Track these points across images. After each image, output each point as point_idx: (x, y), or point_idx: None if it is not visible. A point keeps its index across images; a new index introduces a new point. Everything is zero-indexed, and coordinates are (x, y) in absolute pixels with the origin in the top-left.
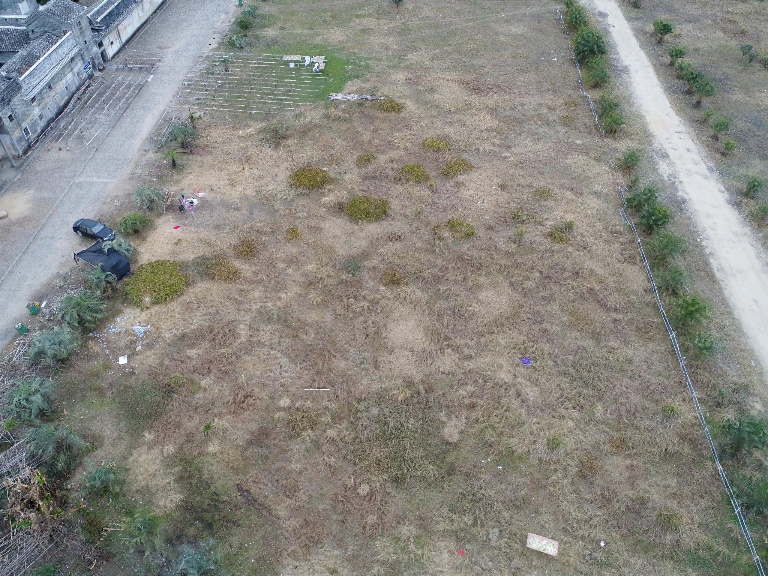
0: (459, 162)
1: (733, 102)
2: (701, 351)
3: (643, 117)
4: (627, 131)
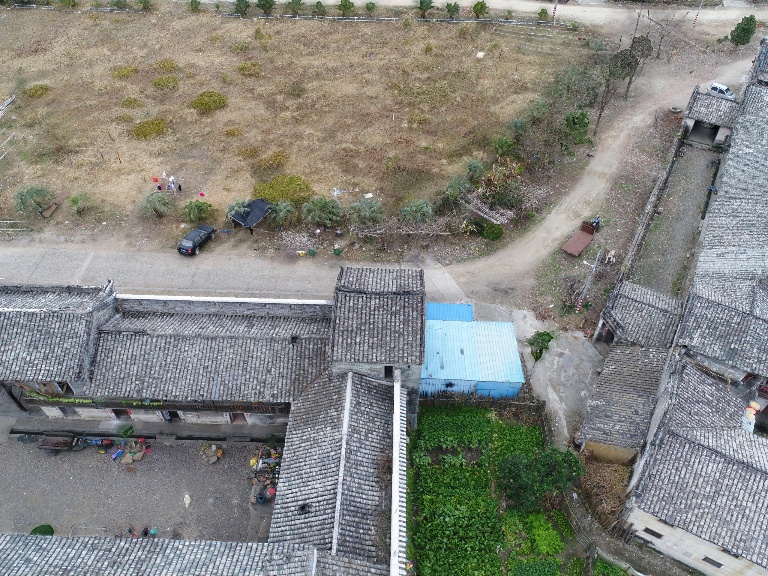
0: (159, 63)
1: None
2: (373, 8)
3: None
4: None
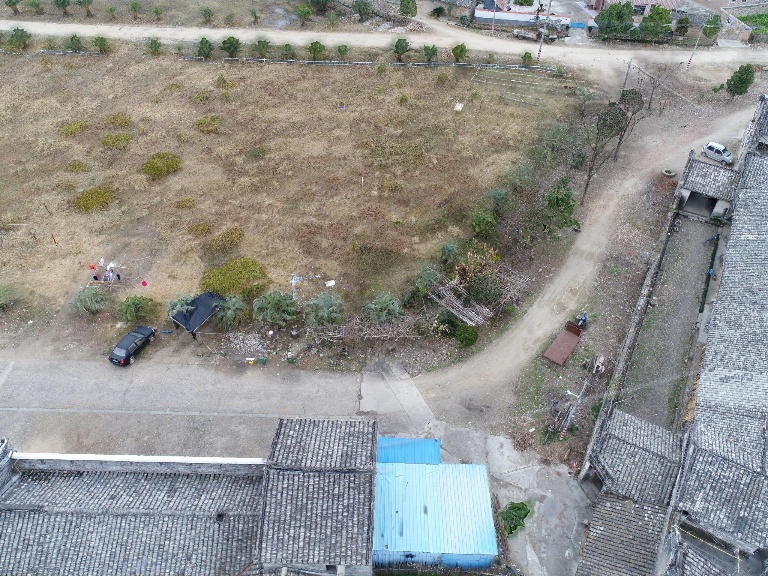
0: (111, 118)
1: (92, 4)
2: (346, 51)
3: (90, 37)
4: (107, 45)
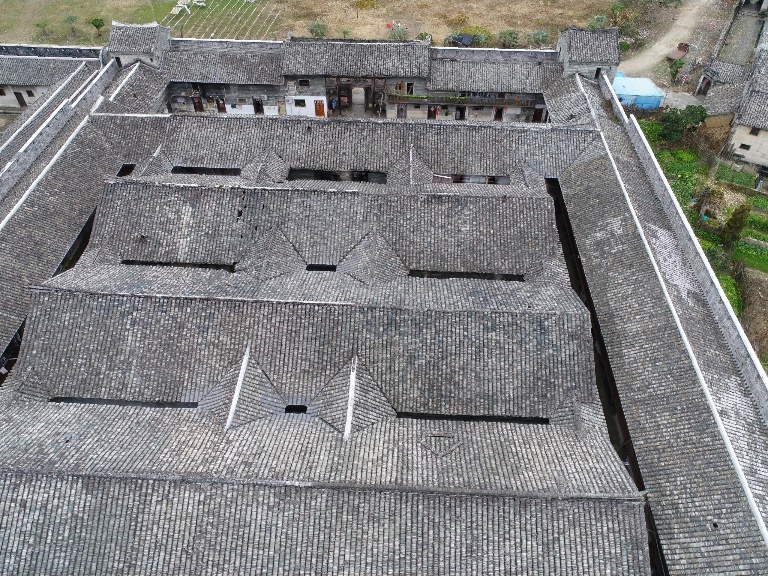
0: None
1: None
2: None
3: None
4: None
